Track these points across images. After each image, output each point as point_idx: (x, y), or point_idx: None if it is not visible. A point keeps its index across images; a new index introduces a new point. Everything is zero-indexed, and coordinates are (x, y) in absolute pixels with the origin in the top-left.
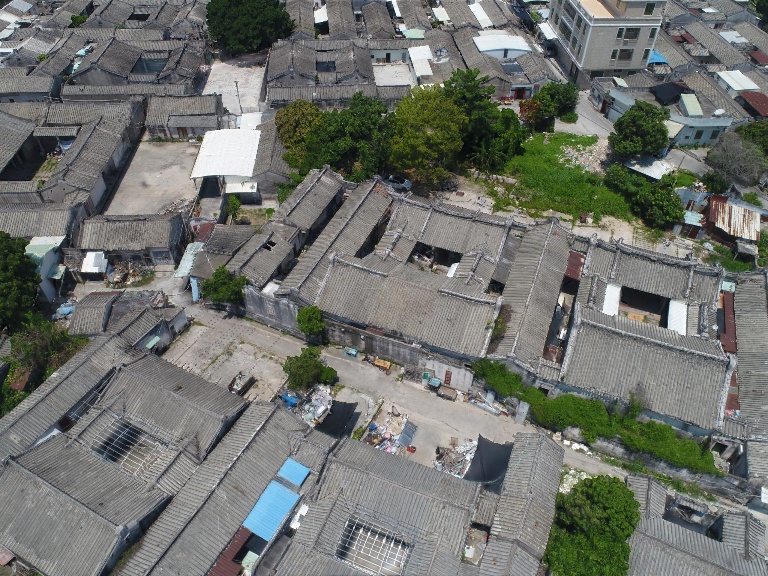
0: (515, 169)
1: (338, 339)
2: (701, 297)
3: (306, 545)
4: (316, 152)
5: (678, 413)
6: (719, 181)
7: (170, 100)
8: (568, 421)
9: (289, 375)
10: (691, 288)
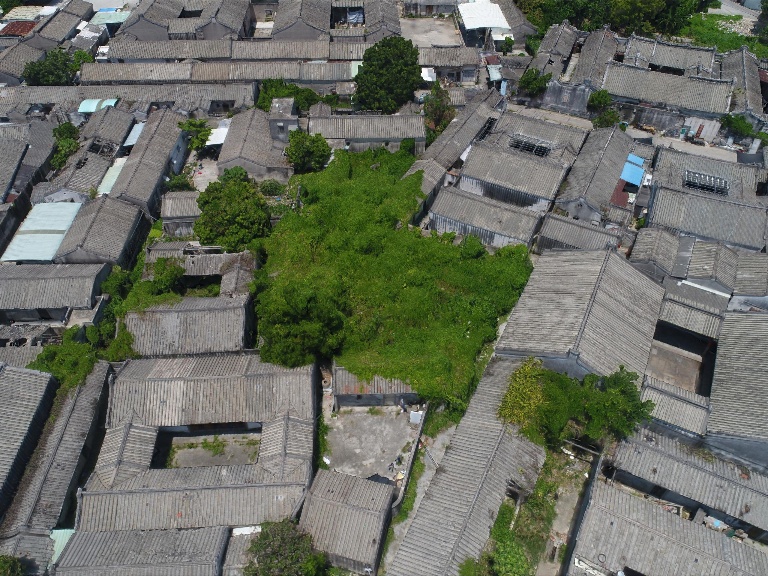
0: None
1: None
2: None
3: None
4: (552, 13)
5: None
6: None
7: None
8: None
9: None
10: None
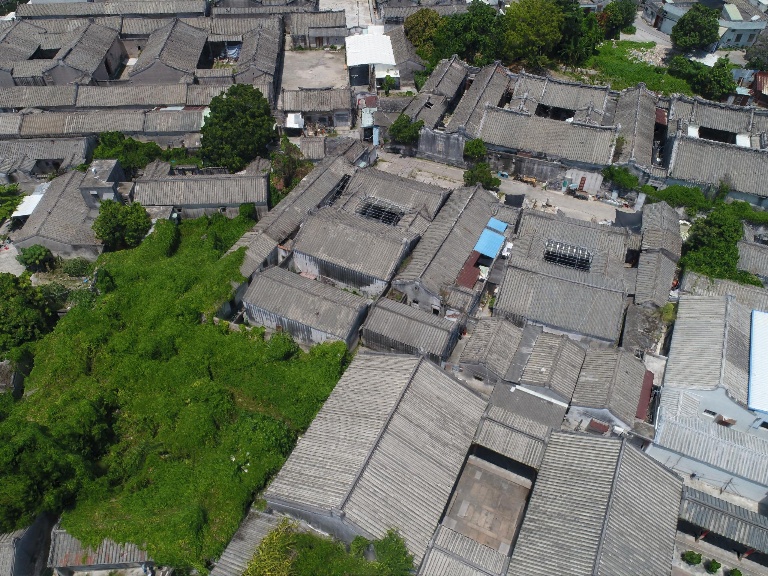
0: (595, 63)
1: (492, 166)
2: (760, 131)
3: None
4: (443, 47)
5: (755, 191)
6: (760, 67)
7: (308, 16)
8: (677, 201)
9: (467, 183)
10: (752, 125)
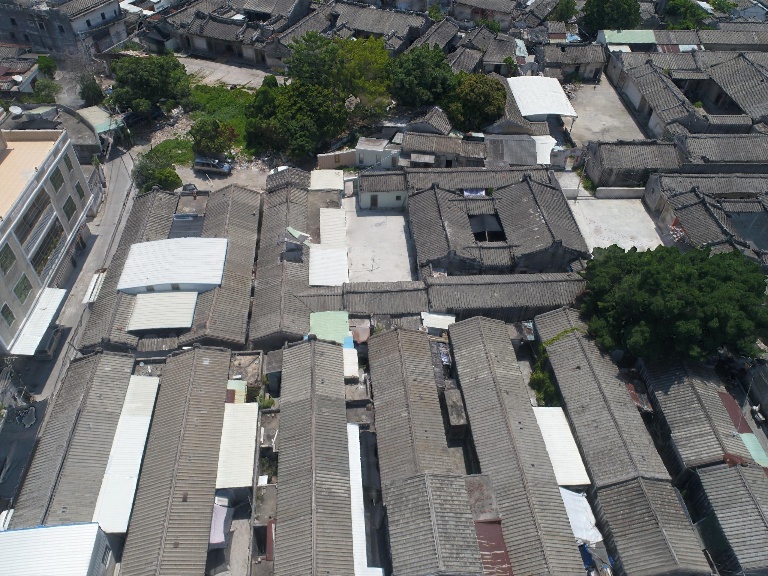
0: None
1: None
2: None
3: None
4: None
5: None
6: None
7: None
8: None
9: None
10: None
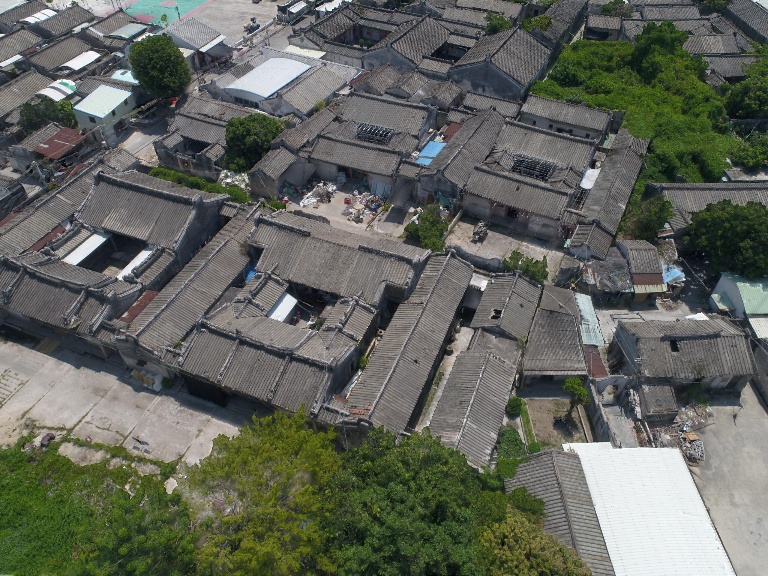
0: None
1: None
2: None
3: (410, 135)
4: None
5: None
6: None
7: None
8: None
9: None
10: None
